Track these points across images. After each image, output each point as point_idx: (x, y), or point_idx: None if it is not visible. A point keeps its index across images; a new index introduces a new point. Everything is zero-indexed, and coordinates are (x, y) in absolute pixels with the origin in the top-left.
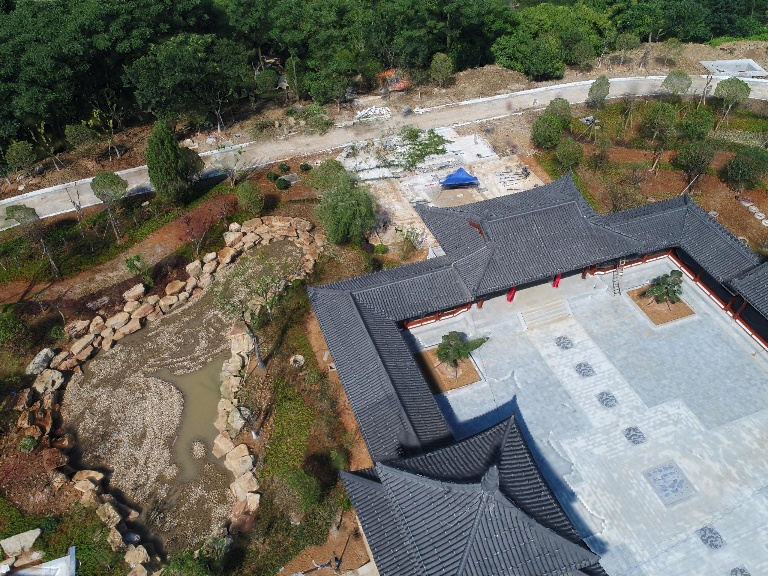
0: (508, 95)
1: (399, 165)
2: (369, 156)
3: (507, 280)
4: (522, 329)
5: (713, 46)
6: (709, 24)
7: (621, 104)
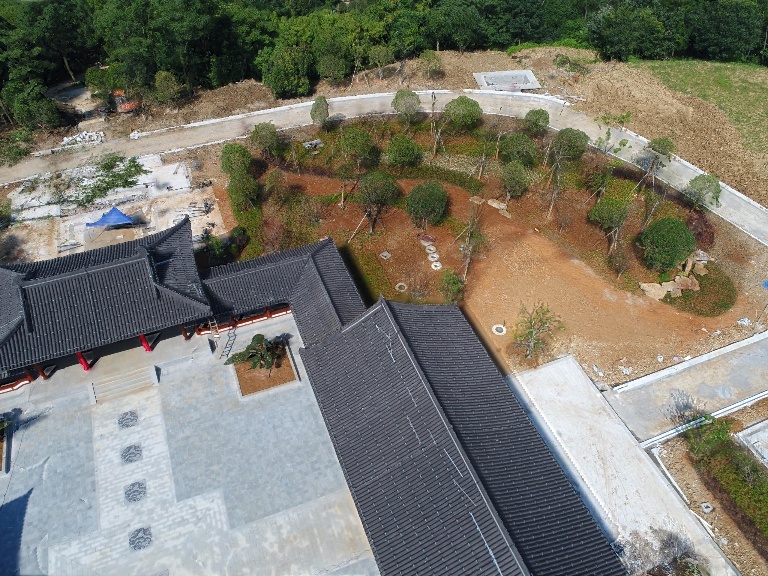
0: (243, 115)
1: (74, 201)
2: (47, 191)
3: (30, 356)
4: (89, 403)
5: (508, 54)
6: (509, 29)
7: (357, 125)
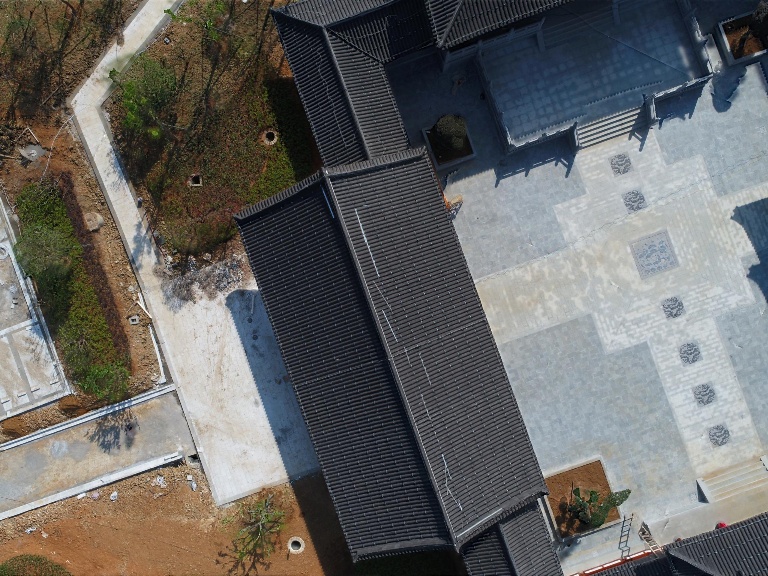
0: None
1: None
2: None
3: None
4: None
5: None
6: None
7: None
